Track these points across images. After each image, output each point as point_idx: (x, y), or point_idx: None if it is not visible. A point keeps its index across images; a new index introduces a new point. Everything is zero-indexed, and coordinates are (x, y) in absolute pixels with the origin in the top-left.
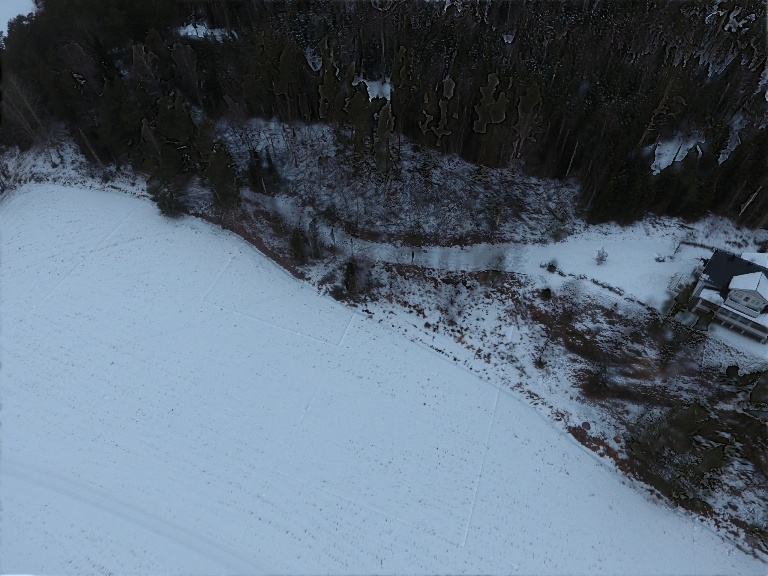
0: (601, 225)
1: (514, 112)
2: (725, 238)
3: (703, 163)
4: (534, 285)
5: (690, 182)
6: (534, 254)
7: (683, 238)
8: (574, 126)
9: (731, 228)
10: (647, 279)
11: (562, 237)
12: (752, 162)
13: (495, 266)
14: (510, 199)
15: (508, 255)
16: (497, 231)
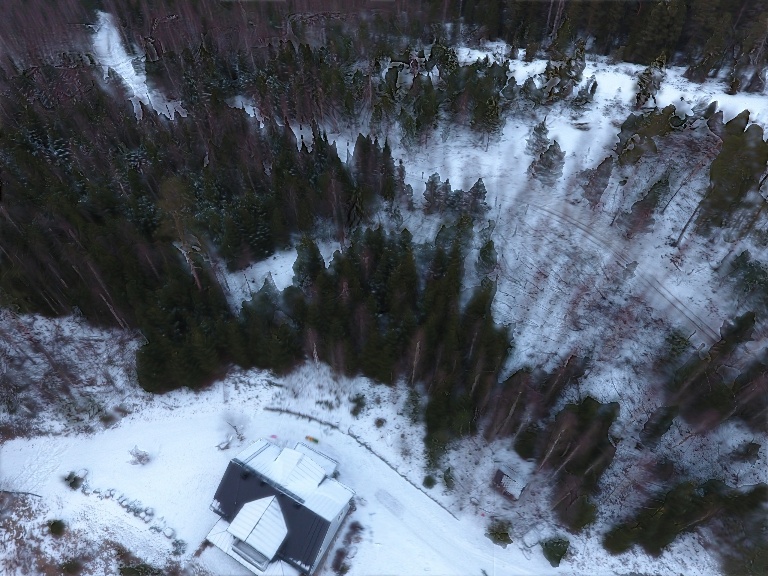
0: (169, 394)
1: (56, 244)
2: (317, 396)
3: (284, 298)
4: (46, 514)
5: (255, 332)
6: (70, 454)
7: (268, 402)
8: (113, 265)
9: (327, 379)
10: (195, 484)
11: (115, 420)
12: (325, 299)
13: (9, 483)
14: (62, 365)
15: (37, 459)
16: (34, 419)
